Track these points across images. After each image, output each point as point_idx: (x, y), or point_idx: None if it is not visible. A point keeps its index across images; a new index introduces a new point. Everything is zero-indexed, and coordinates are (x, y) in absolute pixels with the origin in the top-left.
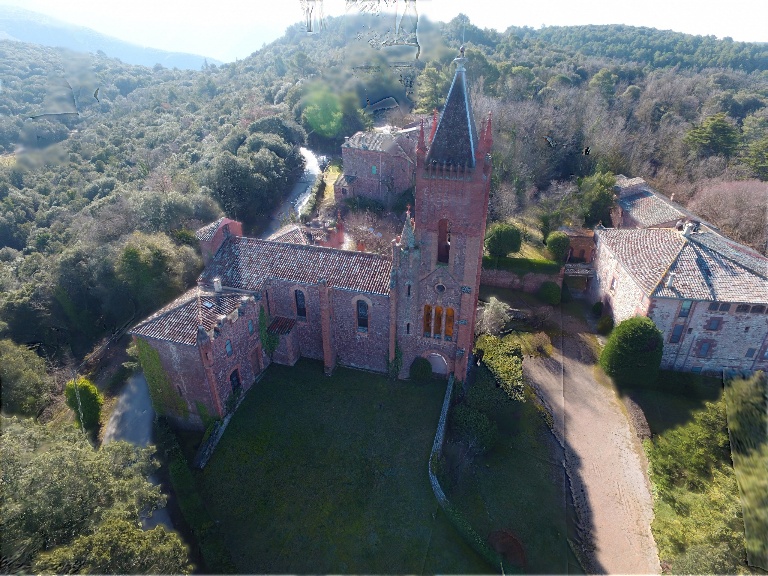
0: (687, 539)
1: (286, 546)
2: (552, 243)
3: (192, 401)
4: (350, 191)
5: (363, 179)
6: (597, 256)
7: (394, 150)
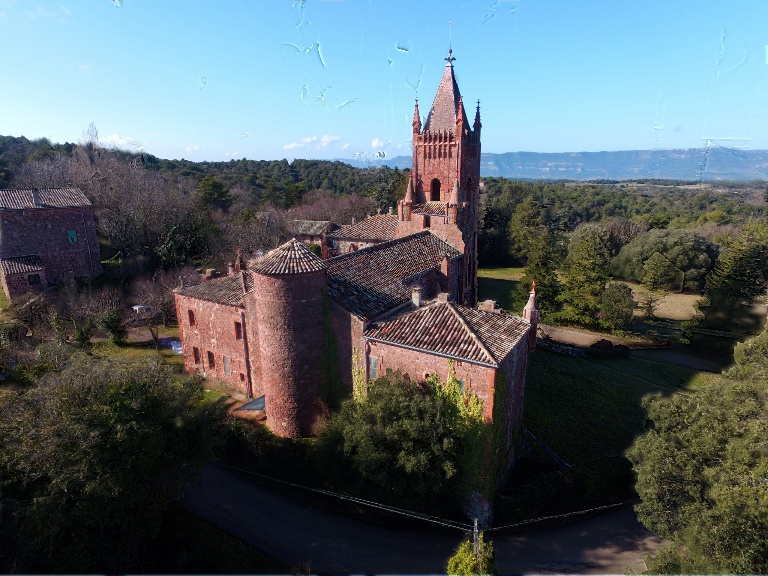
0: (586, 305)
1: (638, 421)
2: (316, 252)
3: (511, 429)
4: (45, 276)
5: (50, 256)
6: (337, 254)
7: (291, 158)
